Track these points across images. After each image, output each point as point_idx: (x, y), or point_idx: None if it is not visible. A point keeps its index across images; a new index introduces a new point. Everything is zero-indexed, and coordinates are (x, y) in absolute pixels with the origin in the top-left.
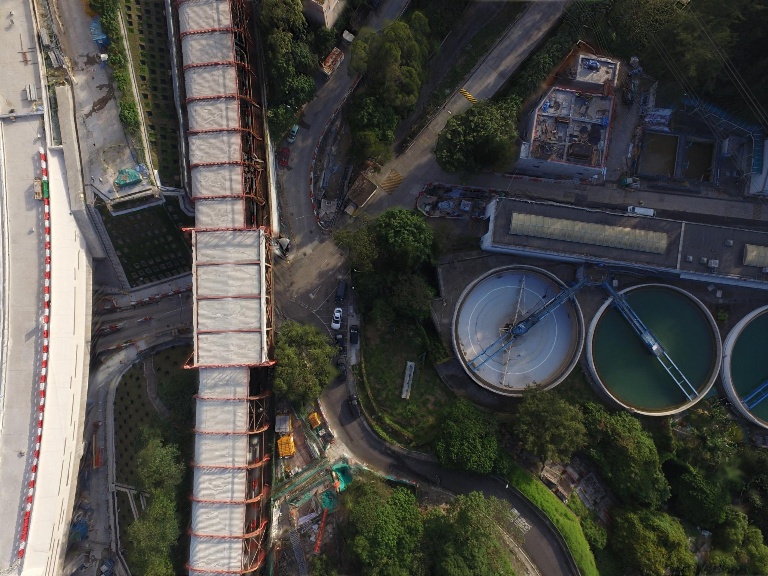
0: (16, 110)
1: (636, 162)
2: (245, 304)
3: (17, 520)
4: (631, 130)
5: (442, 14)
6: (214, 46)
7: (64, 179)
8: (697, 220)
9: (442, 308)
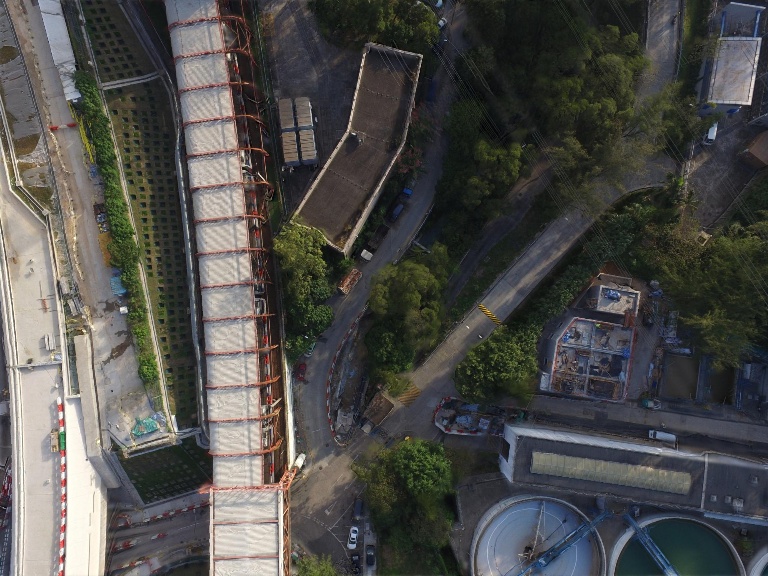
0: (34, 359)
1: (657, 384)
2: (262, 563)
3: None
4: (652, 351)
5: (461, 238)
6: (234, 299)
7: (81, 425)
8: (720, 449)
9: (460, 533)
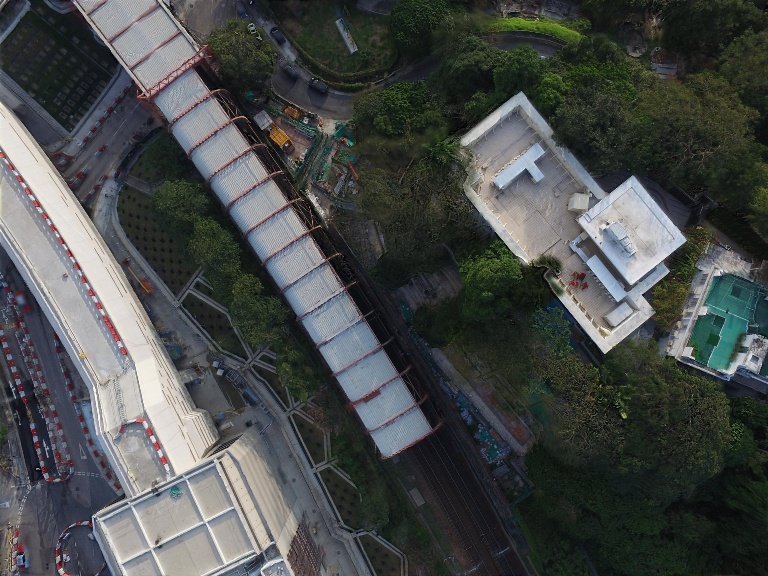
0: None
1: None
2: (152, 20)
3: (101, 330)
4: None
5: None
6: None
7: None
8: None
9: None
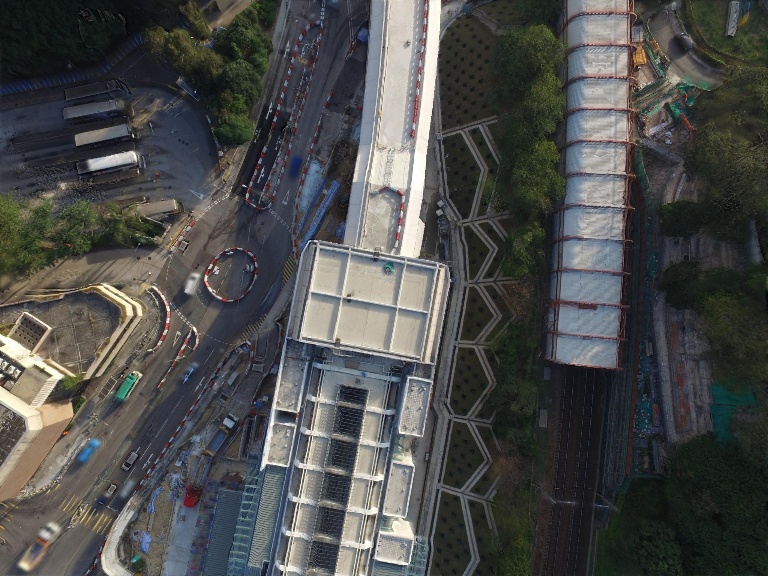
0: None
1: None
2: None
3: (406, 105)
4: None
5: None
6: None
7: None
8: None
9: None
